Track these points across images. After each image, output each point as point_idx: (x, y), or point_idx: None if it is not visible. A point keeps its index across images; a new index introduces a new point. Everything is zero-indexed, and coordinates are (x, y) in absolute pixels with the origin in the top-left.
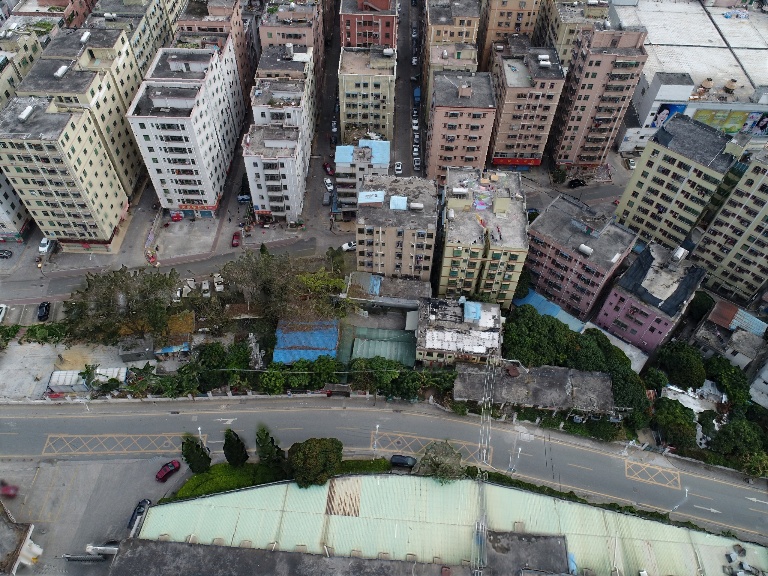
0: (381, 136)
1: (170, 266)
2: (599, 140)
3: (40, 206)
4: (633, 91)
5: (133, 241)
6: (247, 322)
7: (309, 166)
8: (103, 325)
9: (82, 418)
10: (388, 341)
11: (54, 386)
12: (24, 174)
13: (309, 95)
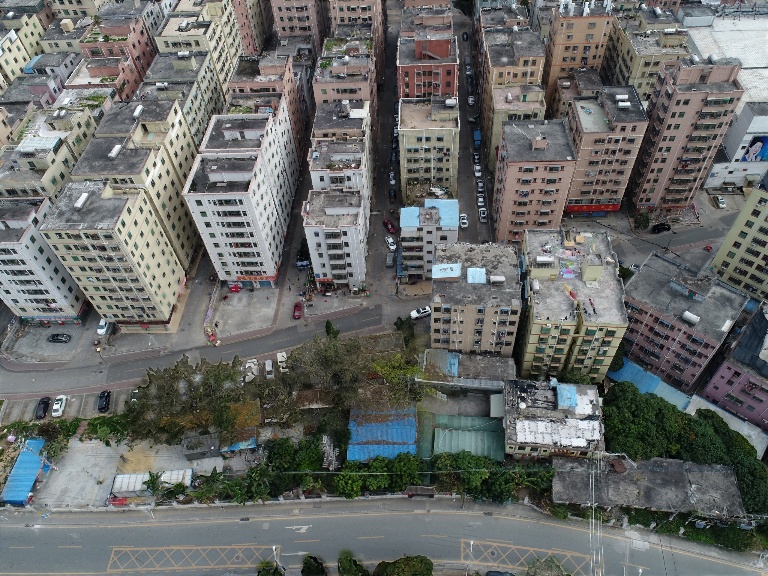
0: (446, 191)
1: (231, 344)
2: (686, 181)
3: (98, 291)
4: (726, 128)
5: (192, 318)
6: (316, 412)
7: (369, 224)
8: (166, 425)
9: (147, 527)
10: (472, 431)
11: (117, 492)
12: (81, 262)
13: (367, 152)
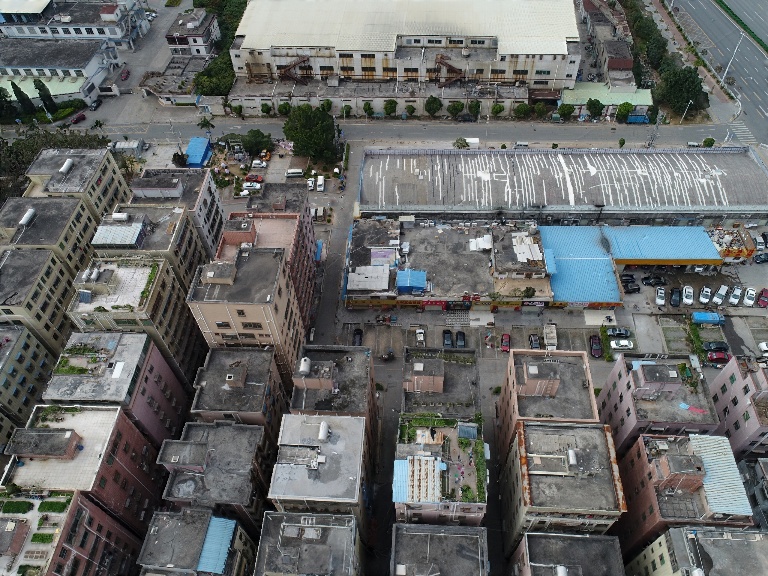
0: None
1: None
2: None
3: None
4: None
5: None
6: (0, 176)
7: None
8: None
9: None
10: None
11: None
12: None
13: None
